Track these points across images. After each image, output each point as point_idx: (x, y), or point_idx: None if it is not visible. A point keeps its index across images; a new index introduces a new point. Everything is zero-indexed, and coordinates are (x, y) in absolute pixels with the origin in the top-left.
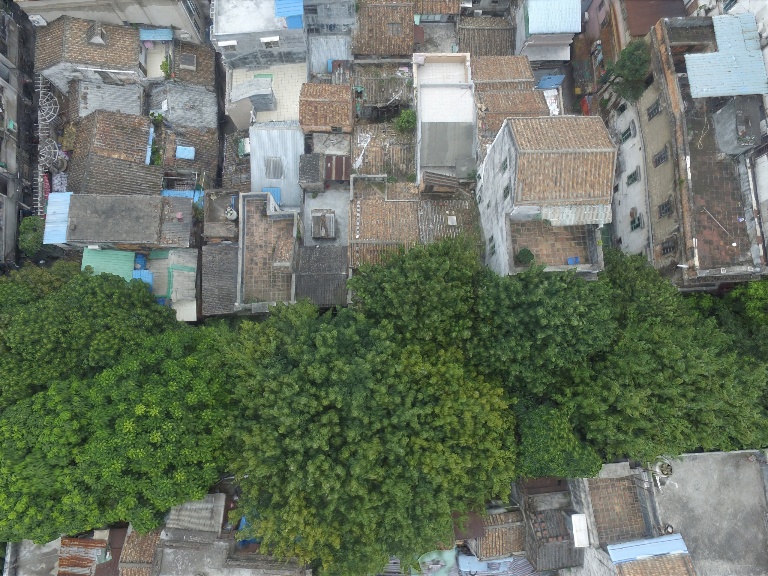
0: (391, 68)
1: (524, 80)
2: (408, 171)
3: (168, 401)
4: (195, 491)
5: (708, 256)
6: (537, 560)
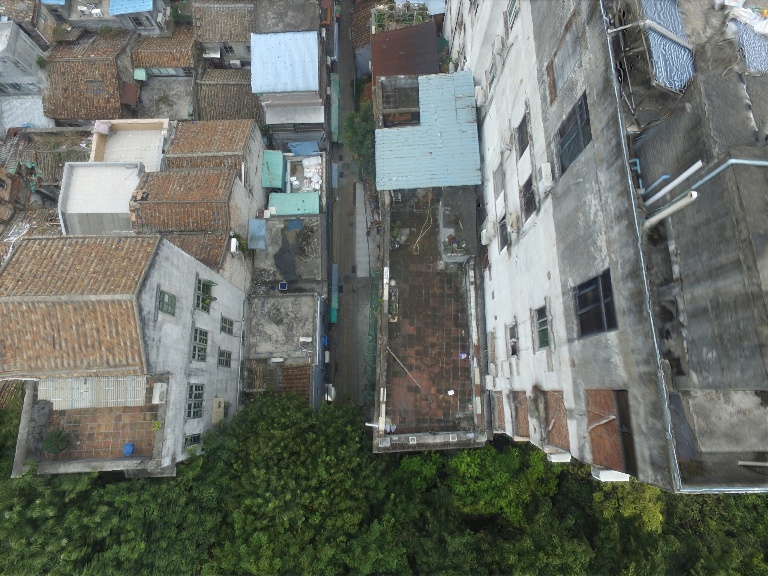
0: (77, 137)
1: (230, 153)
2: None
3: None
4: None
5: (411, 410)
6: None
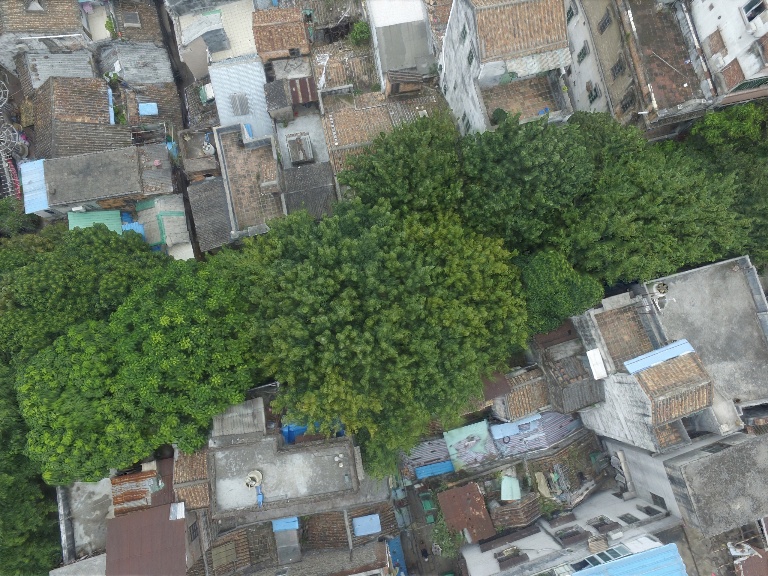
0: None
1: None
2: (371, 82)
3: (190, 309)
4: (233, 395)
5: (664, 100)
6: (563, 403)
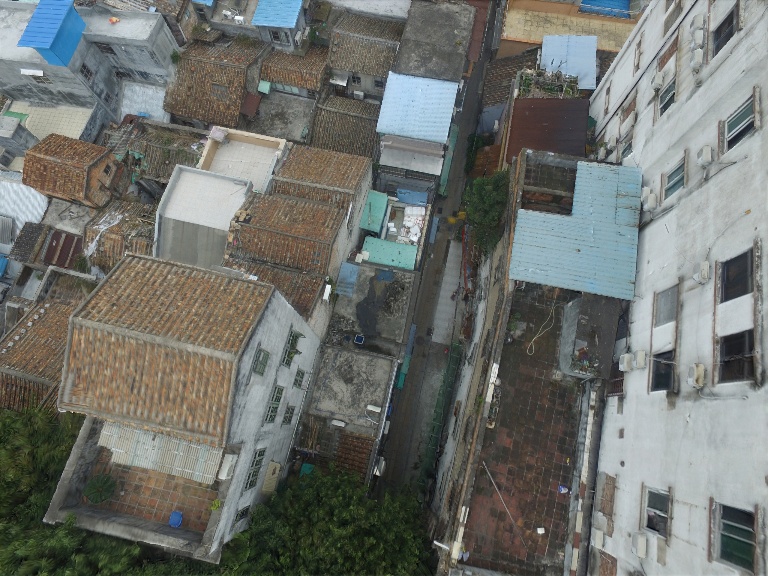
0: (190, 138)
1: (341, 190)
2: None
3: None
4: None
5: (490, 539)
6: None
